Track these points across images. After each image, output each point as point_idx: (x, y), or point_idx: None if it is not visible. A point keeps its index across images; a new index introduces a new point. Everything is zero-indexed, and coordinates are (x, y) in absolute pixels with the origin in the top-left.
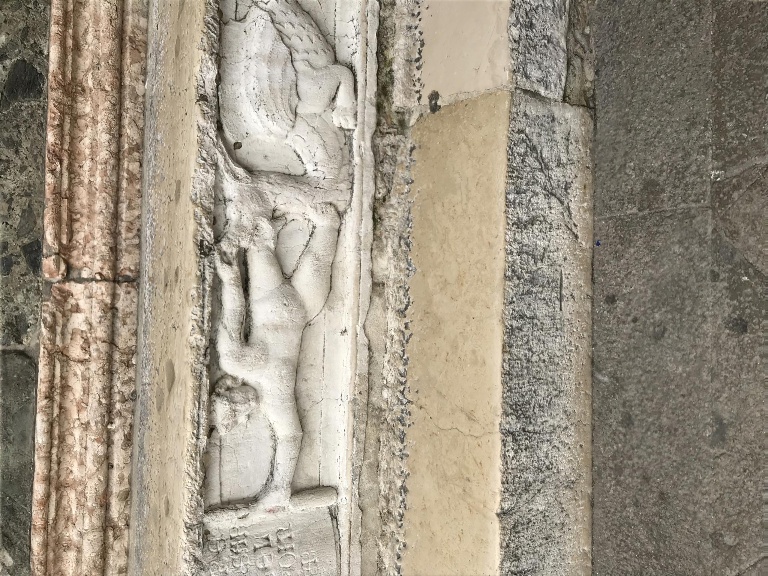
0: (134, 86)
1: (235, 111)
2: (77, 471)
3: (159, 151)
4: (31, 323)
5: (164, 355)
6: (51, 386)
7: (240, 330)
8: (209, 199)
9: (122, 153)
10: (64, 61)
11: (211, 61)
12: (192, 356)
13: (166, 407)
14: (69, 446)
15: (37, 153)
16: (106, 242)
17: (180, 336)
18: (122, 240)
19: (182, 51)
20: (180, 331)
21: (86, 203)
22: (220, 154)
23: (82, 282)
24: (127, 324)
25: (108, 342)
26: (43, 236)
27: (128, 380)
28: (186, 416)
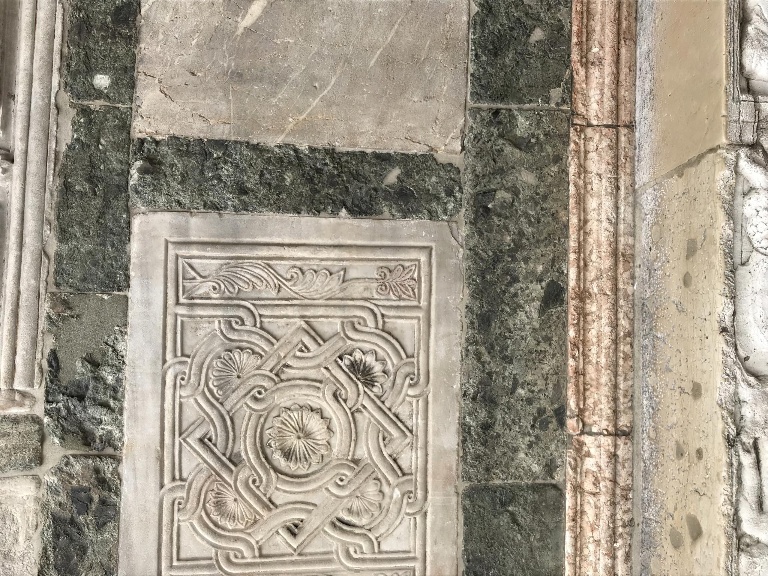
0: (626, 288)
1: (746, 334)
2: (593, 575)
3: (661, 347)
4: (559, 464)
5: (683, 508)
6: (576, 512)
7: (758, 502)
8: (731, 403)
9: (618, 339)
10: (579, 277)
11: (731, 303)
12: (725, 521)
13: (690, 550)
14: (586, 556)
15: (562, 343)
16: (611, 406)
17: (709, 503)
18: (621, 404)
19: (697, 287)
20: (709, 499)
21: (595, 377)
22: (738, 369)
23: (593, 435)
24: (626, 467)
25: (613, 481)
26: (566, 402)
27: (627, 510)
28: (721, 566)
